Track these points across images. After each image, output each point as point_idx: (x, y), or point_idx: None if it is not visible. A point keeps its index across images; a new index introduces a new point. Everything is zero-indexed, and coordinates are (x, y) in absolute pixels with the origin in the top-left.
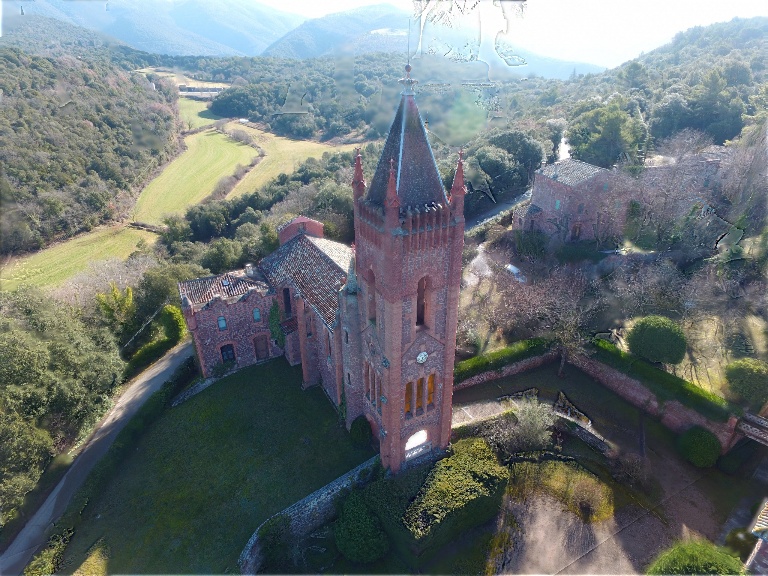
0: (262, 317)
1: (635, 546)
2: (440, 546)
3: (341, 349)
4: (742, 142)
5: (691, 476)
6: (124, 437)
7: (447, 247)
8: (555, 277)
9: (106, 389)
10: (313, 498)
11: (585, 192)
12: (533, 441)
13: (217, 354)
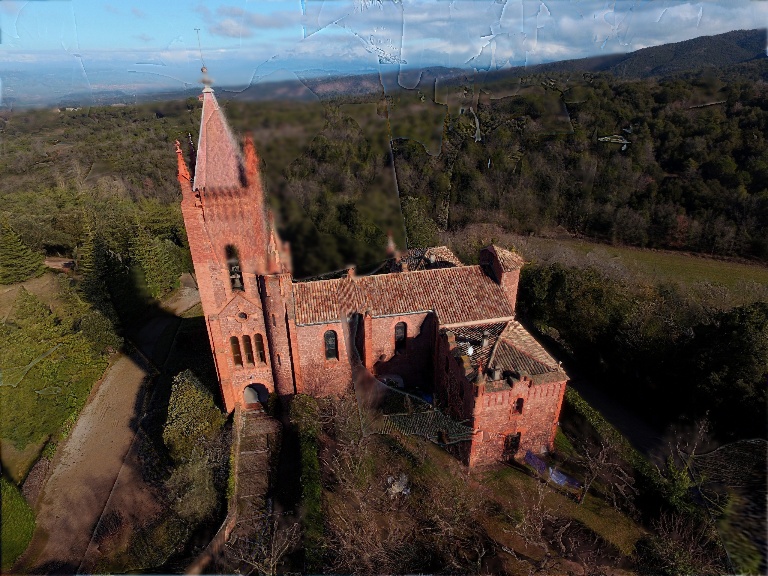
0: None
1: None
2: None
3: None
4: None
5: None
6: None
7: None
8: None
9: (386, 272)
10: None
11: None
12: None
13: None
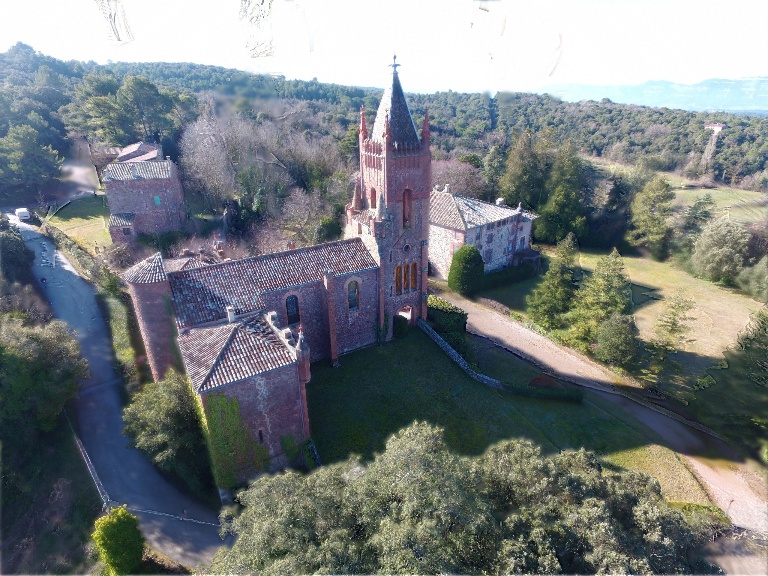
0: None
1: None
2: None
3: None
4: None
5: None
6: None
7: None
8: (263, 230)
9: None
10: None
11: (173, 181)
12: None
13: None
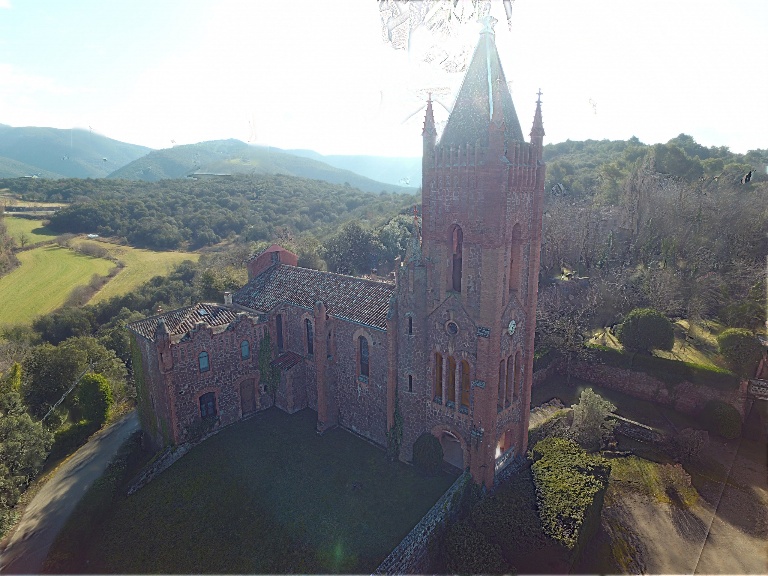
0: (251, 353)
1: (740, 519)
2: (575, 567)
3: (396, 348)
4: (628, 184)
5: (731, 448)
6: (66, 544)
7: (531, 193)
8: None
9: None
10: (411, 541)
11: None
12: (593, 439)
13: (194, 407)
